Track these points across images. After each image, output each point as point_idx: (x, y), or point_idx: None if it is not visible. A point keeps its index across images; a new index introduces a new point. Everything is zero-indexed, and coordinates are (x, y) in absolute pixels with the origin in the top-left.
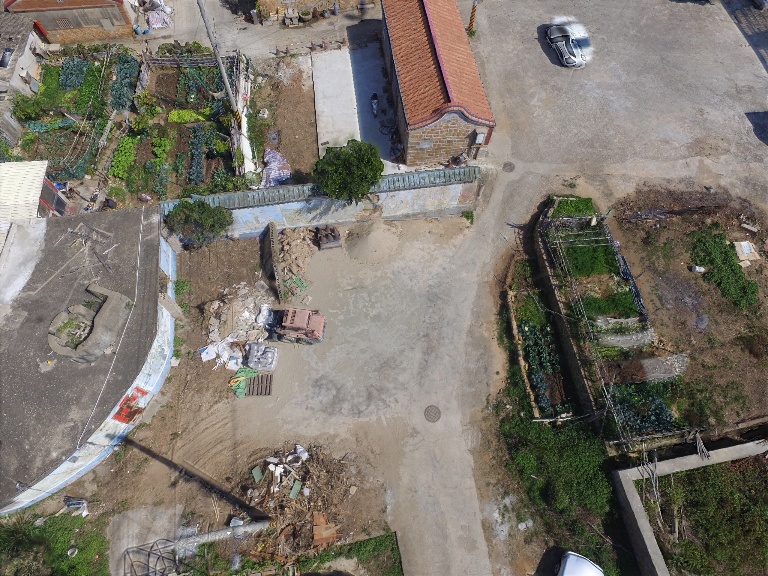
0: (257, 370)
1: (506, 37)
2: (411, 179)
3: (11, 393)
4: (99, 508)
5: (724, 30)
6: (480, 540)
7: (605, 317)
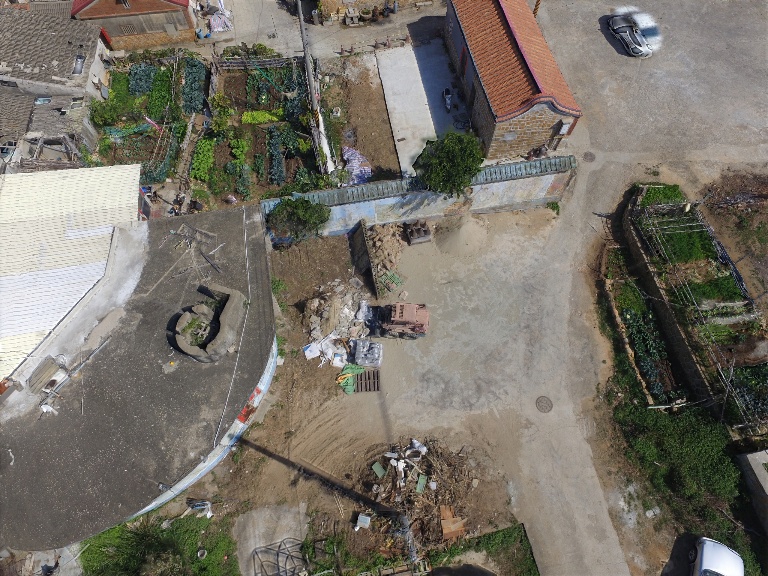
0: (363, 366)
1: (569, 29)
2: (508, 170)
3: (138, 395)
4: (223, 509)
5: None
6: (609, 529)
7: (710, 302)
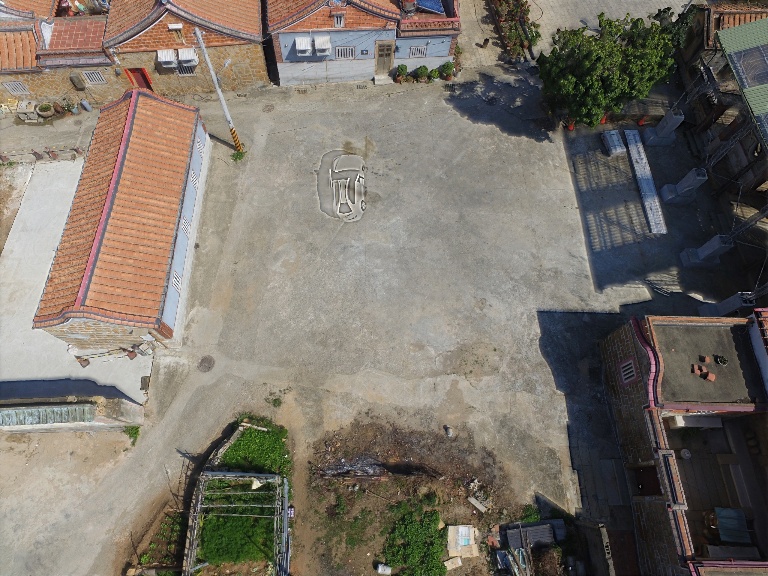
0: None
1: (279, 165)
2: None
3: None
4: None
5: (553, 182)
6: None
7: None
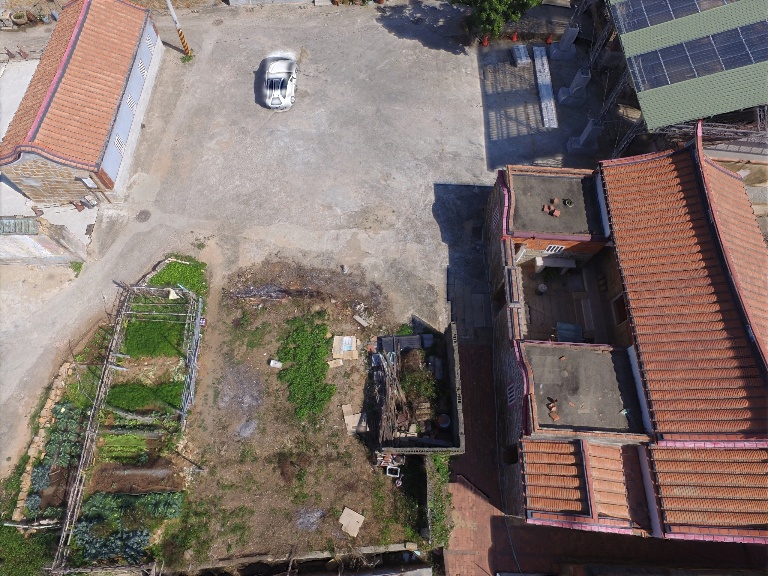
0: None
1: (222, 67)
2: None
3: None
4: None
5: (463, 85)
6: None
7: (137, 410)
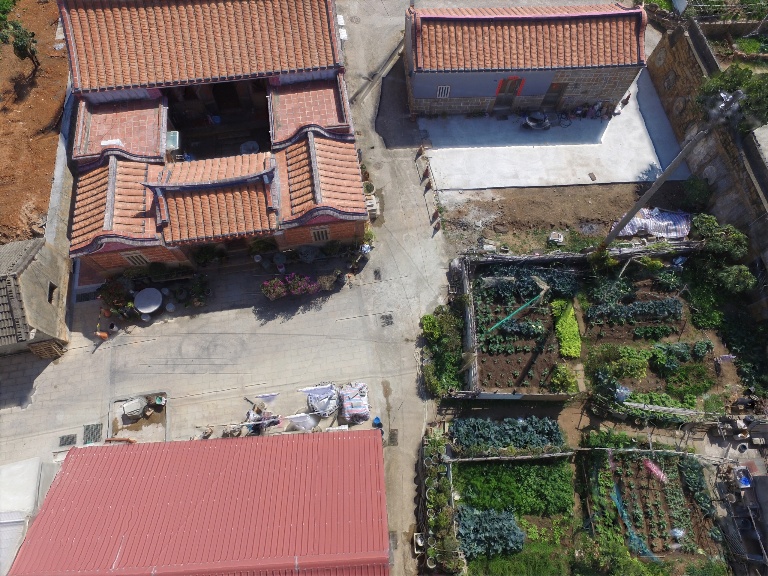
0: None
1: (425, 6)
2: None
3: None
4: None
5: None
6: None
7: None
